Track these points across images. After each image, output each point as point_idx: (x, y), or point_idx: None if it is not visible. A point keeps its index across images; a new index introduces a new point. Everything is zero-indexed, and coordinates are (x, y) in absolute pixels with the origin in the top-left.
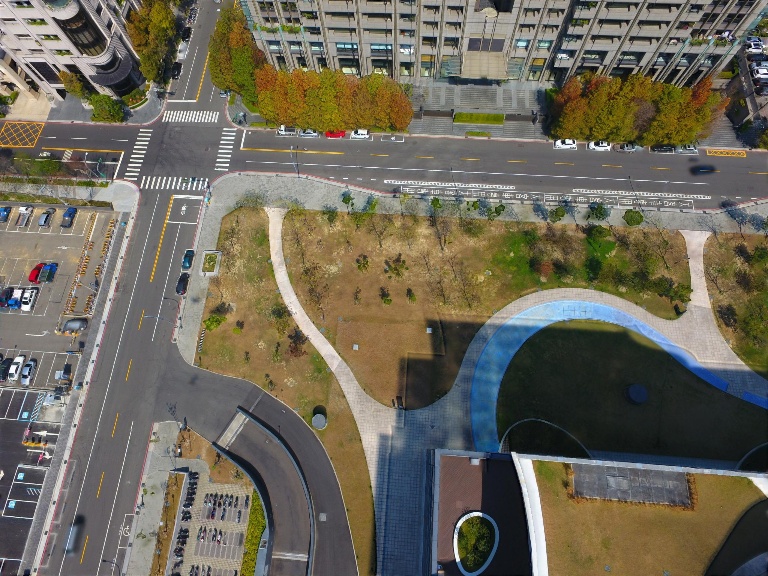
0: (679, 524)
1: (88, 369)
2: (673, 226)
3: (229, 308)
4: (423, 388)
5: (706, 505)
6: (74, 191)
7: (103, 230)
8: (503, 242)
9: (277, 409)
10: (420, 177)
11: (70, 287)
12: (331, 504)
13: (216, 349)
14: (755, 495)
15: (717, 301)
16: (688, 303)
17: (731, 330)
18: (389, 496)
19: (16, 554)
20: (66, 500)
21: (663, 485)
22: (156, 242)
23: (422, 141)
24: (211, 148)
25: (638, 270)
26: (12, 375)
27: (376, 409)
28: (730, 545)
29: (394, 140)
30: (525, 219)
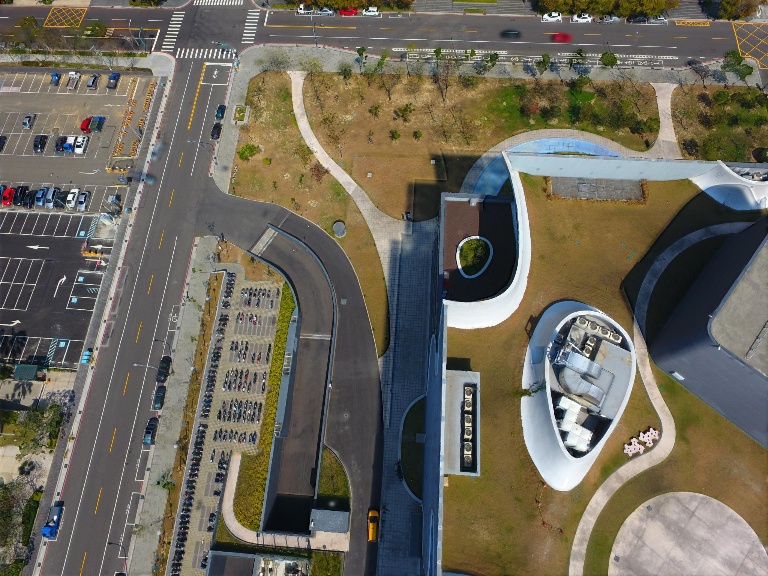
0: (634, 214)
1: (136, 198)
2: (645, 80)
3: (258, 149)
4: (428, 205)
5: (656, 201)
6: (117, 61)
7: (144, 91)
8: (497, 94)
9: (302, 224)
10: (424, 45)
11: (117, 134)
12: (350, 292)
13: (247, 180)
14: (693, 190)
15: (682, 136)
16: (657, 139)
17: (693, 158)
18: (400, 285)
19: (80, 336)
20: (121, 296)
21: (622, 189)
22: (192, 99)
23: (425, 17)
24: (238, 25)
25: (614, 114)
26: (70, 202)
27: (388, 221)
28: (673, 225)
29: (401, 17)
30: (516, 76)
